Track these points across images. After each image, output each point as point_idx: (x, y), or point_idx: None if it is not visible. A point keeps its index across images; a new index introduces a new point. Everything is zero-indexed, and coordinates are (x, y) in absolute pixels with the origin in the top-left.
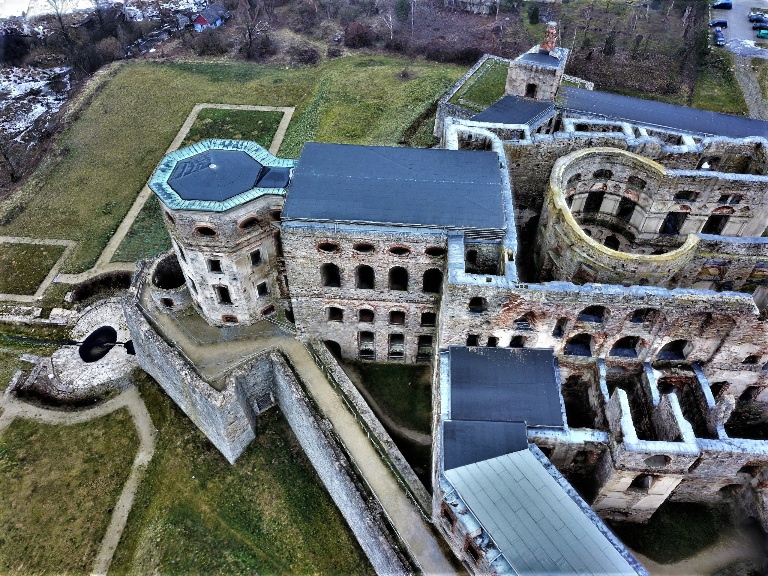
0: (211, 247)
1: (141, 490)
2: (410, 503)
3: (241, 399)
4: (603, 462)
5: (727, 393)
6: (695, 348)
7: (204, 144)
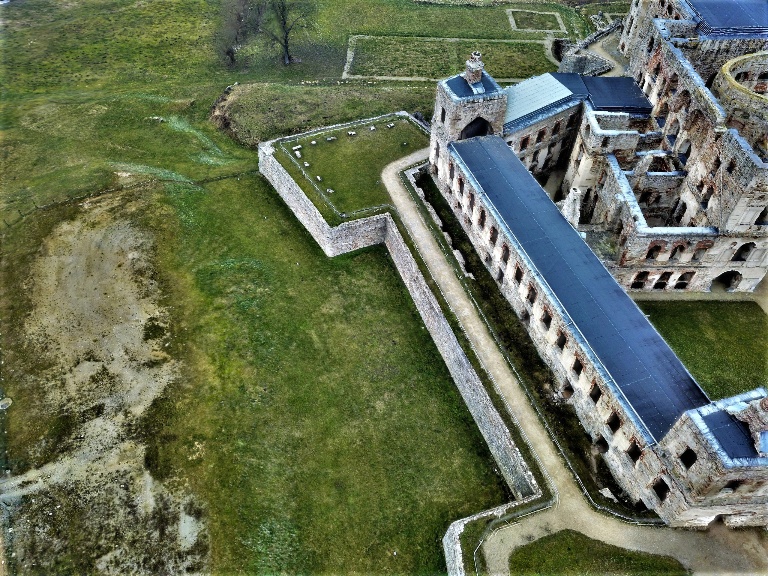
0: None
1: None
2: None
3: (577, 69)
4: None
5: None
6: (690, 155)
7: None
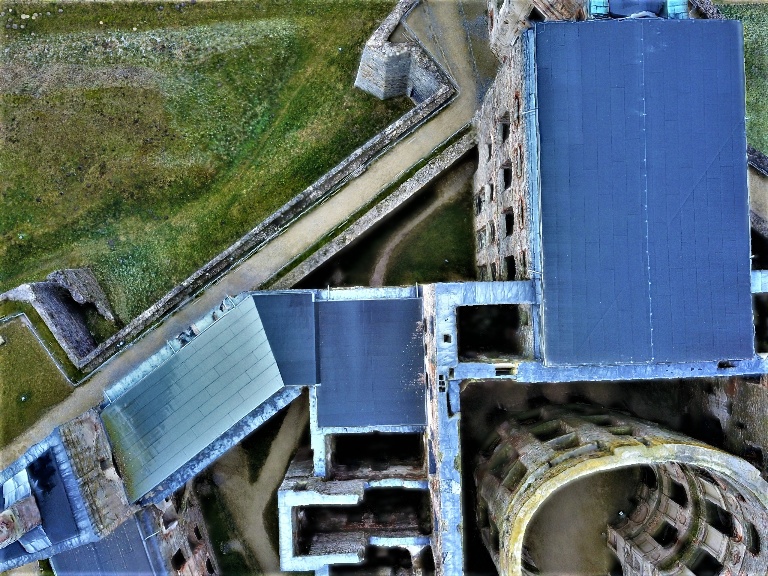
0: None
1: (325, 1)
2: None
3: (395, 68)
4: (307, 468)
5: None
6: None
7: None
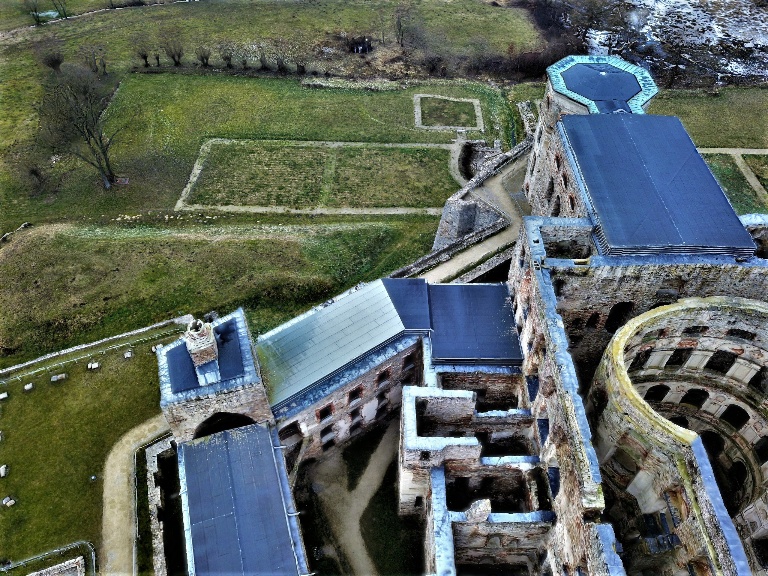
0: None
1: (409, 215)
2: None
3: (465, 219)
4: None
5: None
6: (559, 493)
7: (637, 69)
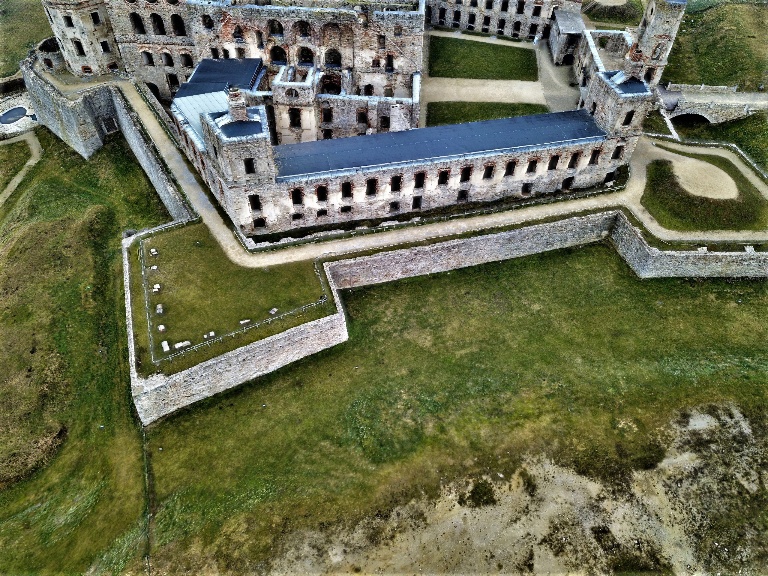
0: (64, 5)
1: (28, 174)
2: (172, 143)
3: (89, 111)
4: None
5: (376, 95)
6: (342, 56)
7: None
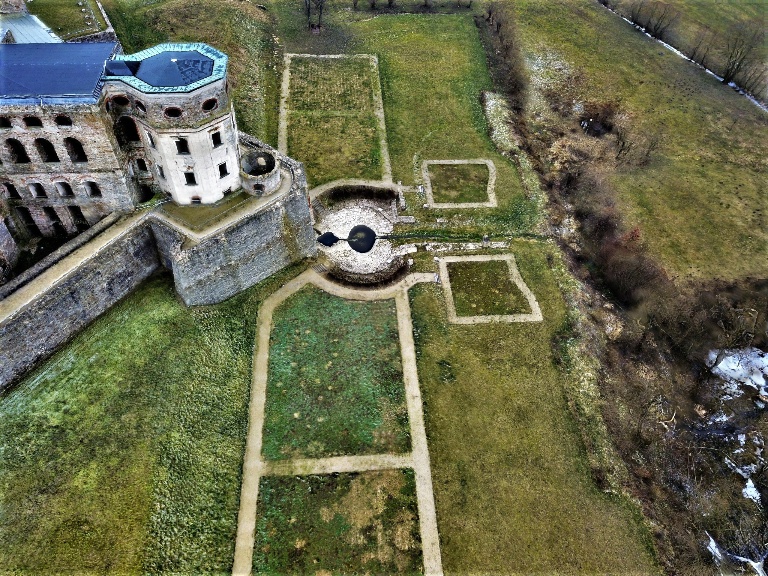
0: None
1: None
2: None
3: None
4: None
5: None
6: None
7: (191, 87)
